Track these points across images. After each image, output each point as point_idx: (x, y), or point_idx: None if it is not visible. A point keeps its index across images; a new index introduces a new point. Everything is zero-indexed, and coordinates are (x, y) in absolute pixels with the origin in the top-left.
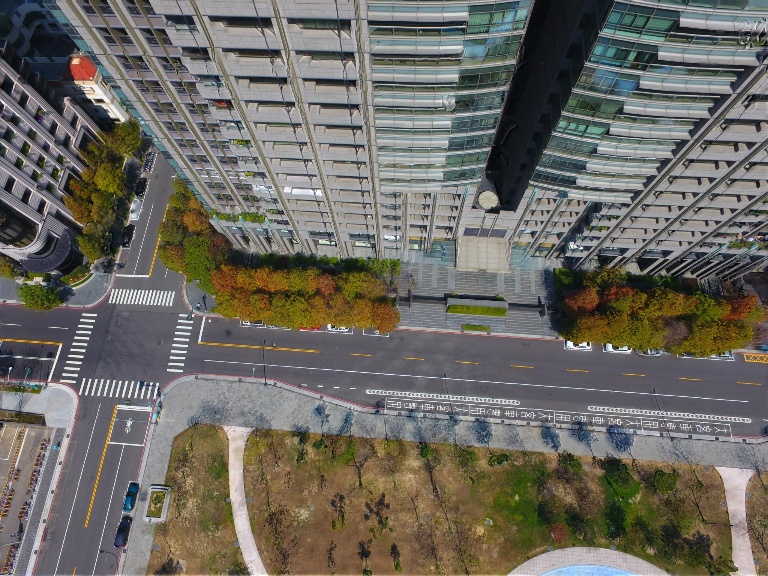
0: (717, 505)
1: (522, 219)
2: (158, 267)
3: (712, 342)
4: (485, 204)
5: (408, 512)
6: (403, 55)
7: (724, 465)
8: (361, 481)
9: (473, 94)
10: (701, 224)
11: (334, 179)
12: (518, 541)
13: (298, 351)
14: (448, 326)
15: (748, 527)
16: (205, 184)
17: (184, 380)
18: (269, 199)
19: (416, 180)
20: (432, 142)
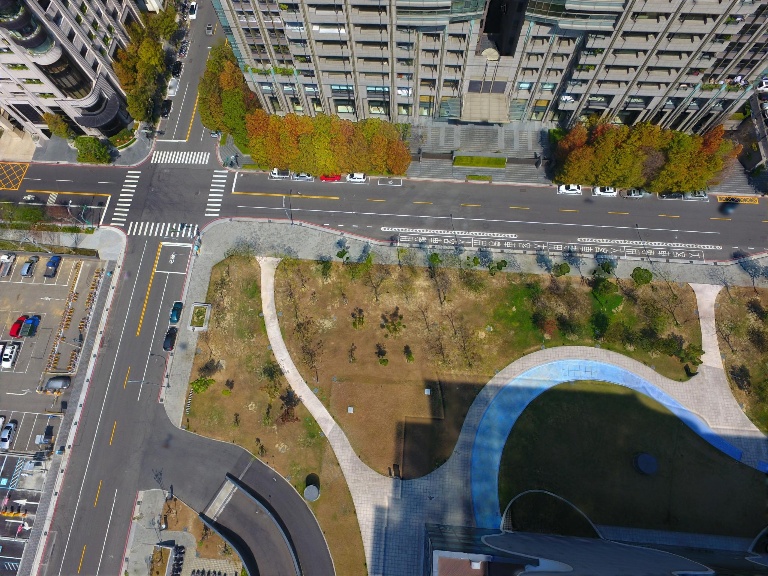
0: (690, 313)
1: (520, 65)
2: (194, 133)
3: (686, 171)
4: None
5: (419, 321)
6: None
7: (697, 282)
8: None
9: None
10: (675, 58)
11: (357, 11)
12: (515, 342)
13: (321, 198)
14: (454, 177)
15: (716, 330)
16: (242, 31)
17: (220, 222)
18: (298, 43)
19: (427, 12)
20: None
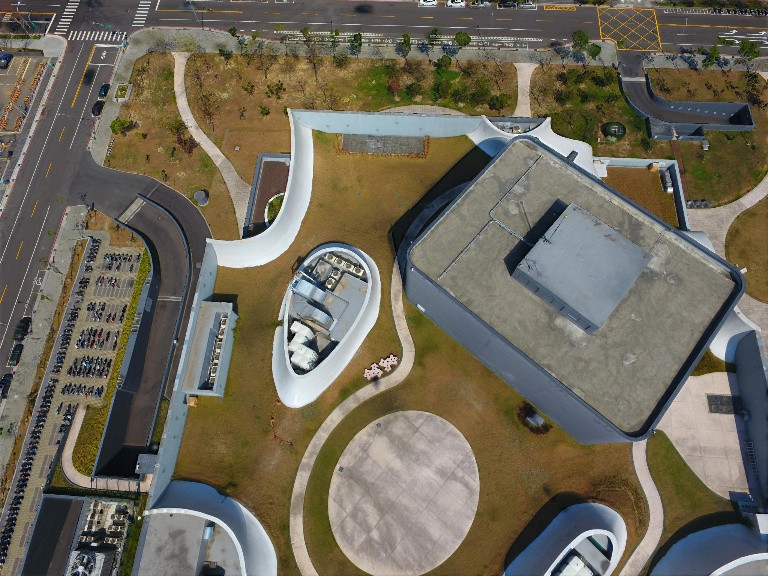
0: (511, 82)
1: None
2: None
3: None
4: None
5: (298, 92)
6: None
7: (519, 62)
8: (266, 77)
9: None
10: None
11: None
12: (372, 104)
13: (227, 12)
14: None
15: (530, 93)
16: None
17: (144, 30)
18: None
19: None
20: None
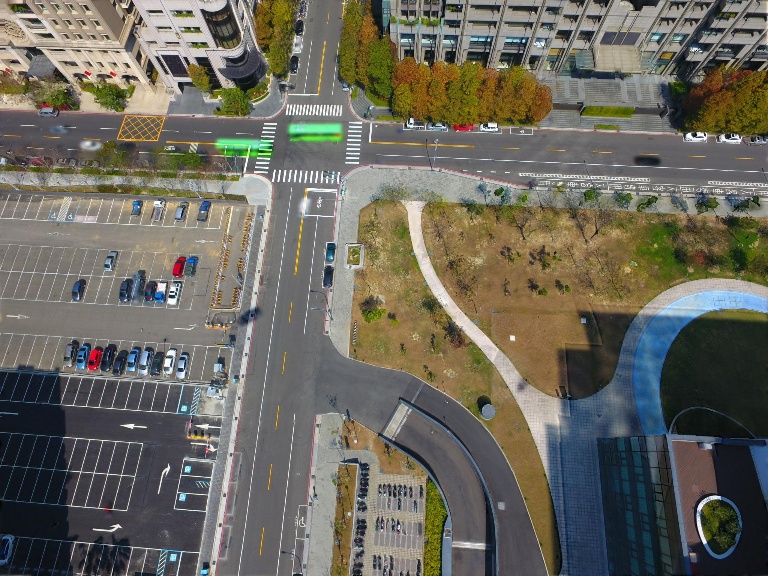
0: None
1: (660, 15)
2: (324, 88)
3: None
4: None
5: (566, 258)
6: None
7: None
8: (524, 237)
9: None
10: None
11: None
12: (660, 275)
13: (456, 146)
14: (583, 126)
15: None
16: None
17: (361, 169)
18: None
19: None
20: None
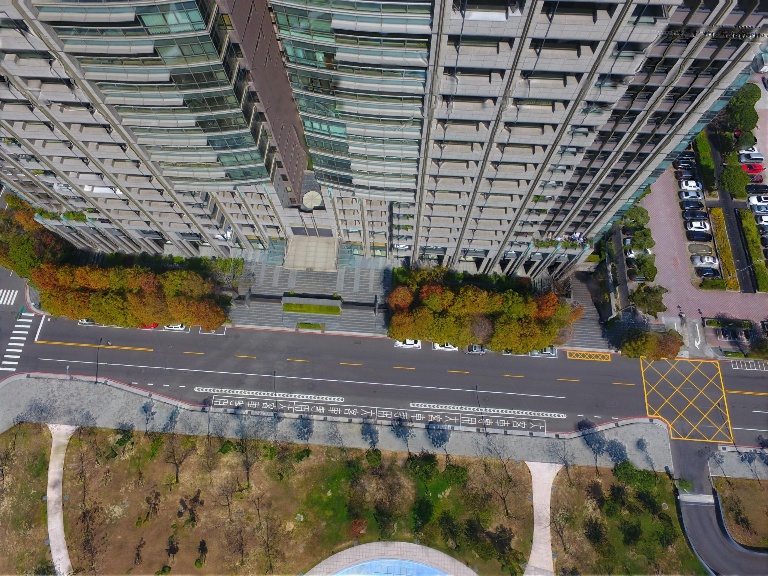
0: (523, 499)
1: (336, 218)
2: None
3: (519, 339)
4: (309, 204)
5: (221, 508)
6: (100, 54)
7: (534, 460)
8: (178, 478)
9: (197, 93)
10: (496, 223)
11: (123, 177)
12: (325, 536)
13: (133, 349)
14: (284, 324)
15: (551, 520)
16: (16, 182)
17: (16, 379)
18: None
19: (206, 179)
20: (191, 141)
